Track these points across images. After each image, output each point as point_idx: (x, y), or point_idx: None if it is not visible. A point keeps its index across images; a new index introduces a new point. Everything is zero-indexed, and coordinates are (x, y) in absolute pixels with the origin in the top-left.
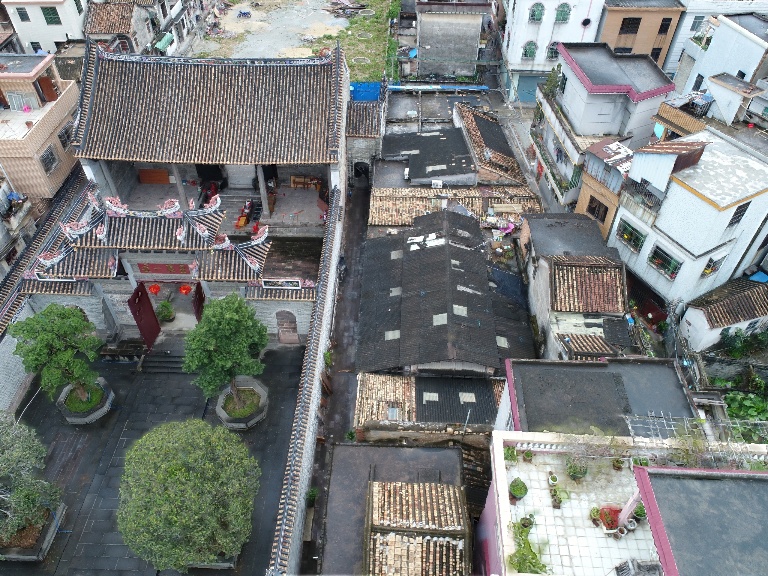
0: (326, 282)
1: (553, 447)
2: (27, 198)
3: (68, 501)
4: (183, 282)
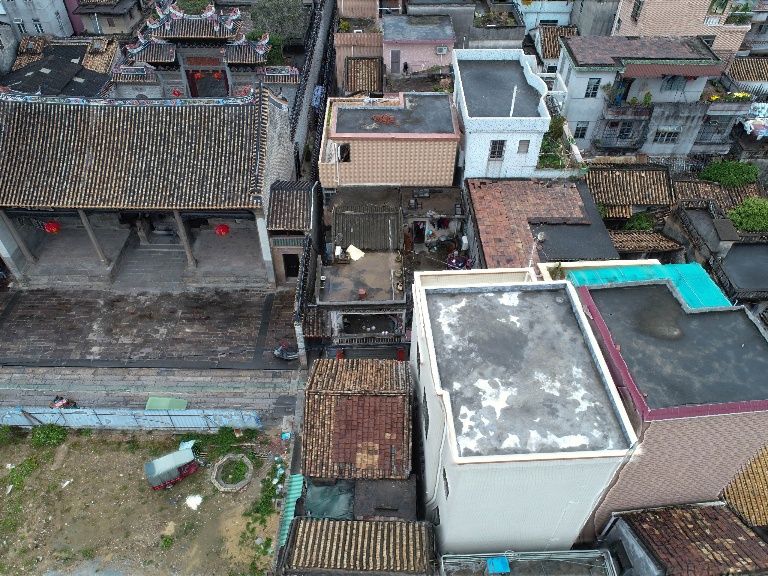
0: None
1: None
2: None
3: None
4: None
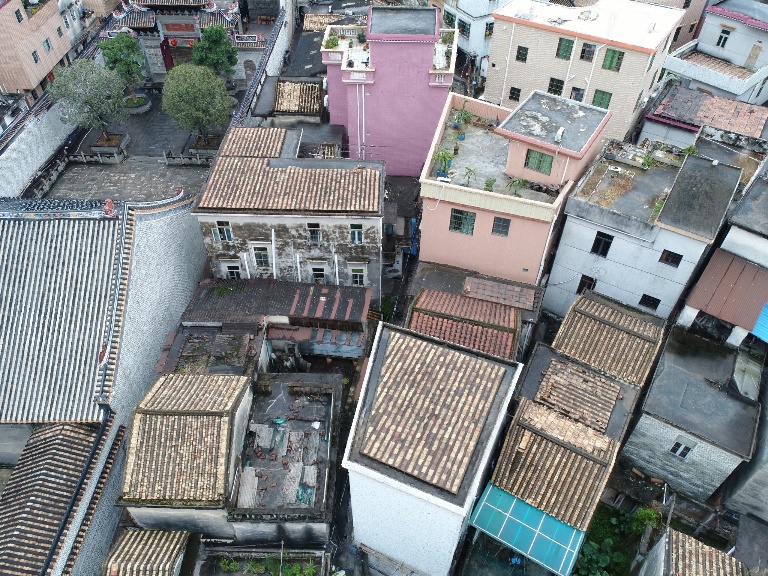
0: (272, 43)
1: (354, 33)
2: (93, 12)
3: (131, 137)
4: (191, 37)
